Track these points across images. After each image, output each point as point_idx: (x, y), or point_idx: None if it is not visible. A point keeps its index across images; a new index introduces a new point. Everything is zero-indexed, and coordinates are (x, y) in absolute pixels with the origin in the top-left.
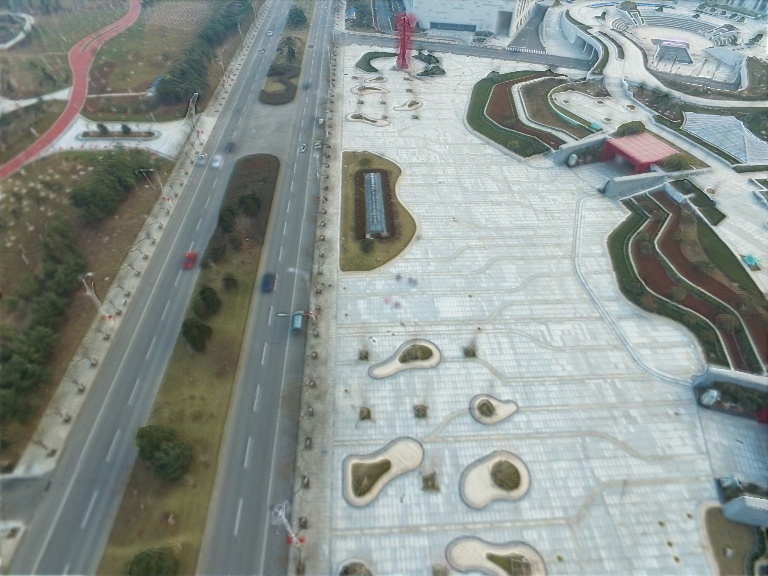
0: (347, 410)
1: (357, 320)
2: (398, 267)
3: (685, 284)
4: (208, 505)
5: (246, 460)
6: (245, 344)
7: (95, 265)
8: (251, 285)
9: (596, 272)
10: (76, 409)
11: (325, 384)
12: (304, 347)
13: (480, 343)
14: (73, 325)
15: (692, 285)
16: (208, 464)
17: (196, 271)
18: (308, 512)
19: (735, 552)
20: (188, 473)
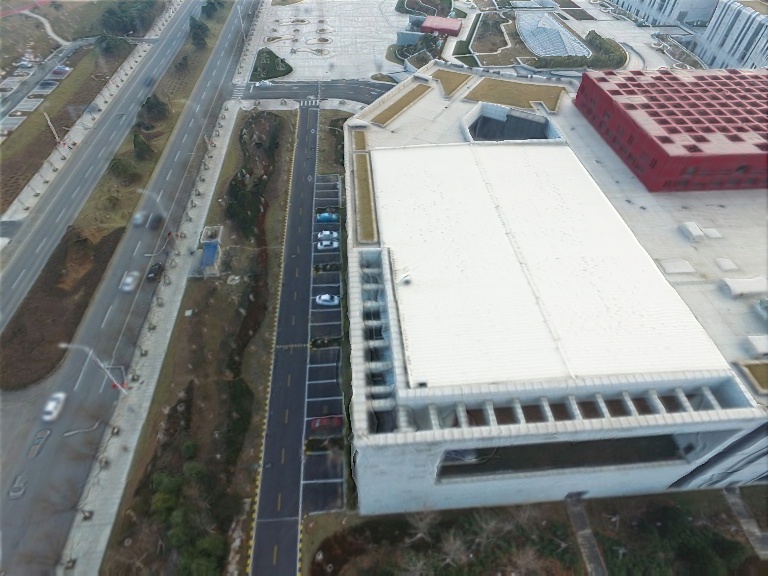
0: (268, 30)
1: (276, 15)
2: (298, 5)
3: (422, 5)
4: (216, 42)
5: (229, 37)
6: (228, 19)
7: (159, 1)
8: (230, 8)
9: (388, 7)
10: (163, 29)
11: (260, 26)
12: (252, 19)
13: (327, 20)
14: (155, 12)
15: (425, 5)
16: (215, 36)
17: (205, 4)
18: (251, 43)
19: (394, 49)
20: (208, 32)
